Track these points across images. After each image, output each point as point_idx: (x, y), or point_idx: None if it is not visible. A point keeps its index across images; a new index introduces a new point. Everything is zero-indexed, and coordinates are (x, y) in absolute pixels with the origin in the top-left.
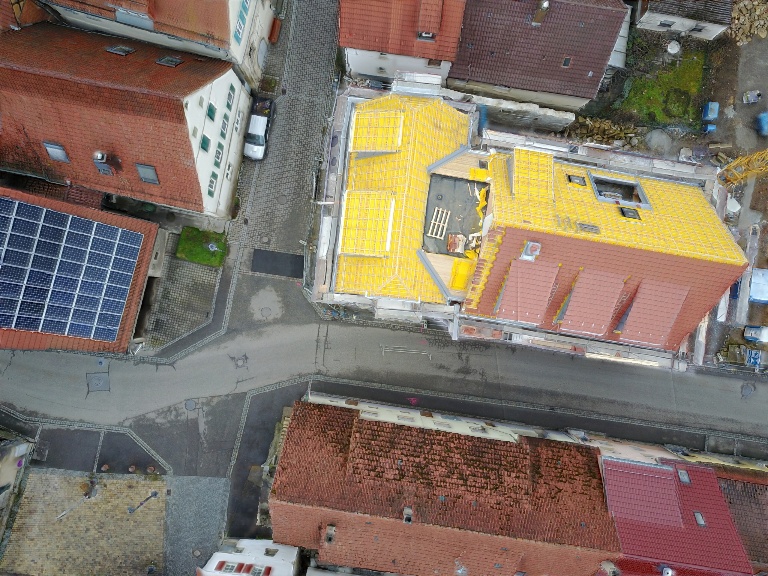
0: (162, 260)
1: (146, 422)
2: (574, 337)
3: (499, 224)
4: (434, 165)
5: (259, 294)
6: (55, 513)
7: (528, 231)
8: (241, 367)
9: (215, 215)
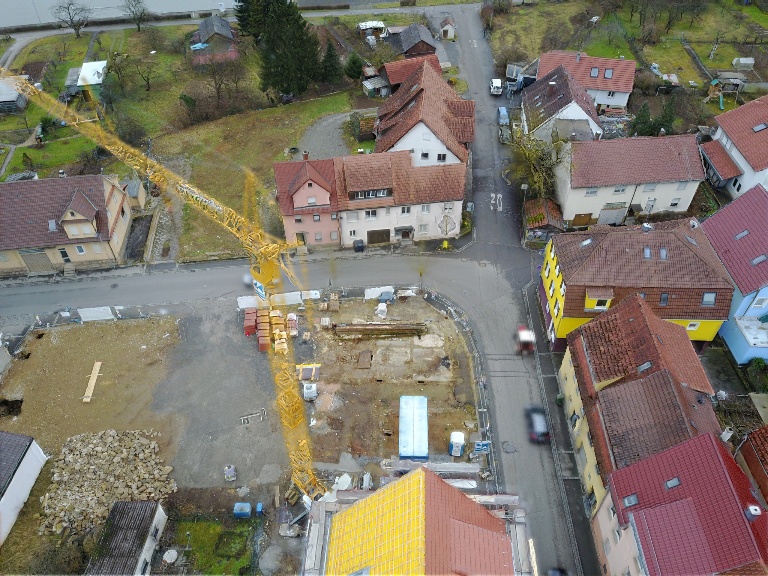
0: None
1: None
2: None
3: None
4: None
5: None
6: None
7: None
8: None
9: None
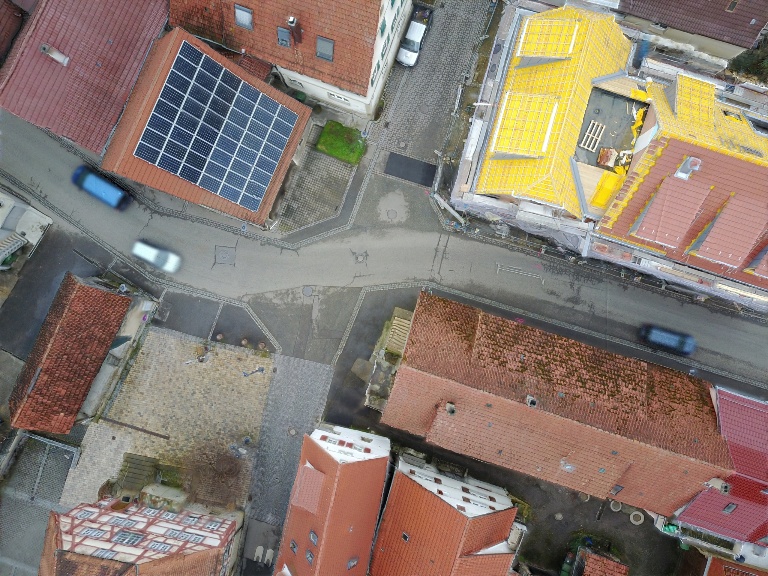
0: (303, 149)
1: (264, 300)
2: (702, 271)
3: (664, 134)
4: (597, 79)
5: (388, 196)
6: (167, 372)
7: (691, 145)
8: (360, 263)
9: (364, 109)
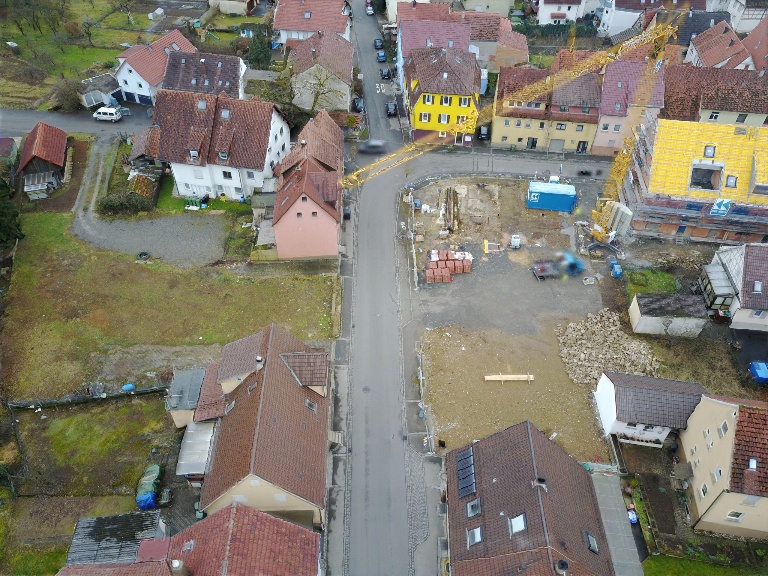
0: None
1: None
2: None
3: None
4: None
5: None
6: None
7: None
8: None
9: None
